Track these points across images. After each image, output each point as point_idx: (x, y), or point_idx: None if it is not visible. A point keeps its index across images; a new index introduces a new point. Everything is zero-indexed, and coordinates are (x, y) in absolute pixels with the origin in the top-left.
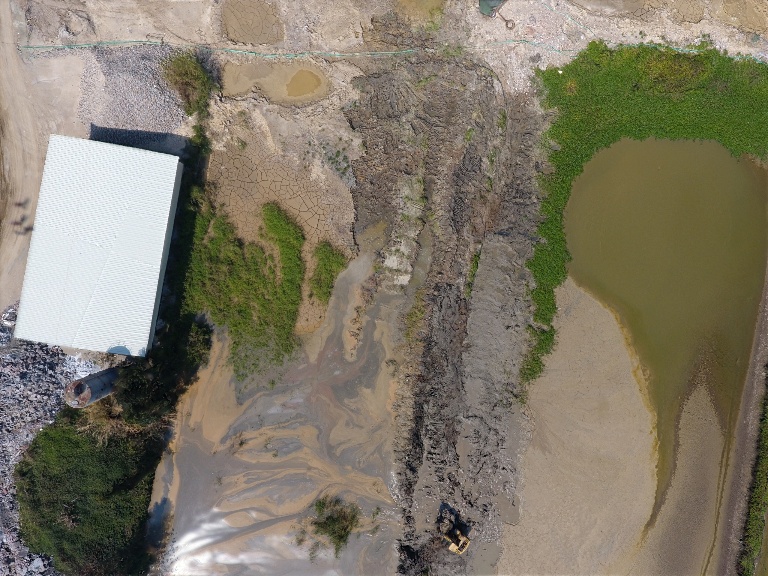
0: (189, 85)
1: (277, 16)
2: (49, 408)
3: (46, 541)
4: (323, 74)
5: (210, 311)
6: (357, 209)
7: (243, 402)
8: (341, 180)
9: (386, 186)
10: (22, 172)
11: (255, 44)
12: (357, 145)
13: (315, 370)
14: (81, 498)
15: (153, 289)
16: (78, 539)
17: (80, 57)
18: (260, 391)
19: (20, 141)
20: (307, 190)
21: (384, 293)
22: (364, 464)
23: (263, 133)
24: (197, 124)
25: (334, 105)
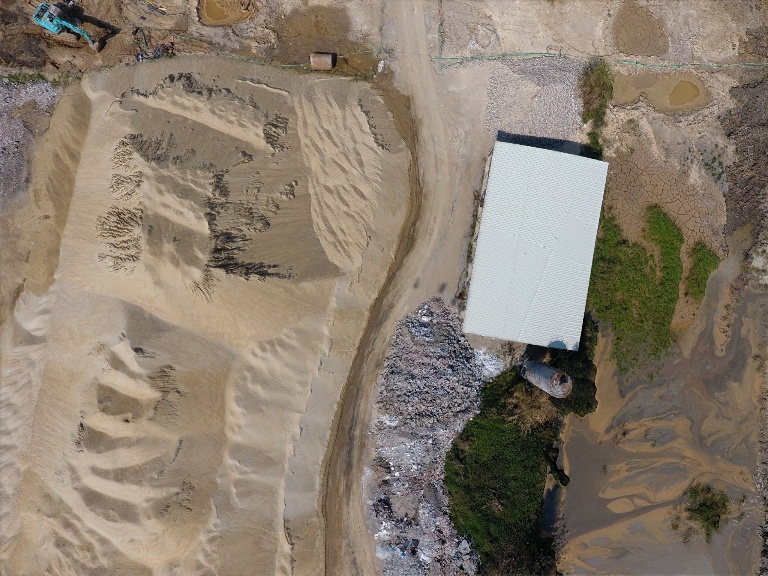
0: (601, 95)
1: (663, 29)
2: (473, 399)
3: (472, 524)
4: (702, 84)
5: (595, 308)
6: (727, 212)
7: (625, 395)
8: (716, 185)
9: (753, 191)
10: (434, 176)
11: (643, 56)
12: (731, 152)
13: (688, 365)
14: (504, 484)
15: (585, 287)
16: (501, 522)
17: (486, 68)
18: (640, 384)
19: (433, 147)
20: (685, 194)
21: (750, 292)
22: (732, 454)
23: (648, 140)
24: (591, 131)
25: (713, 114)
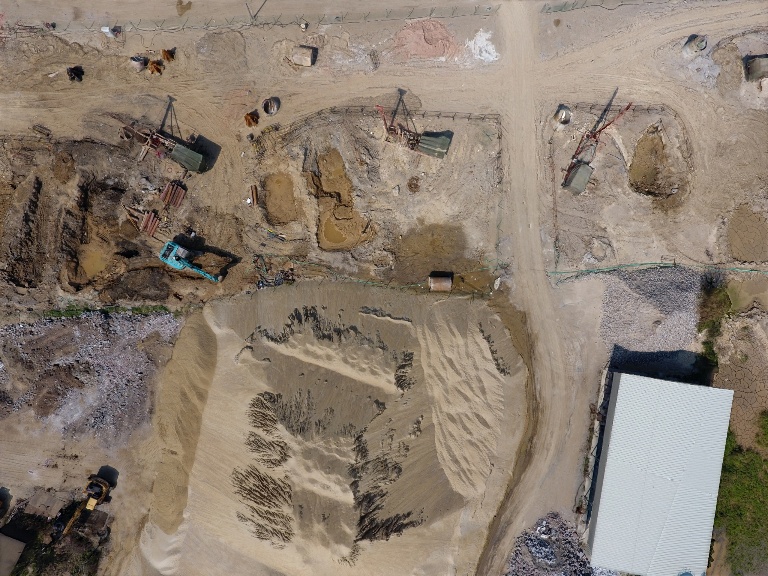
0: None
1: None
2: None
3: None
4: None
5: None
6: None
7: None
8: None
9: None
10: (551, 391)
11: (757, 262)
12: None
13: None
14: None
15: (712, 516)
16: None
17: (601, 280)
18: None
19: (549, 362)
20: None
21: None
22: None
23: (763, 346)
24: (706, 340)
25: None
